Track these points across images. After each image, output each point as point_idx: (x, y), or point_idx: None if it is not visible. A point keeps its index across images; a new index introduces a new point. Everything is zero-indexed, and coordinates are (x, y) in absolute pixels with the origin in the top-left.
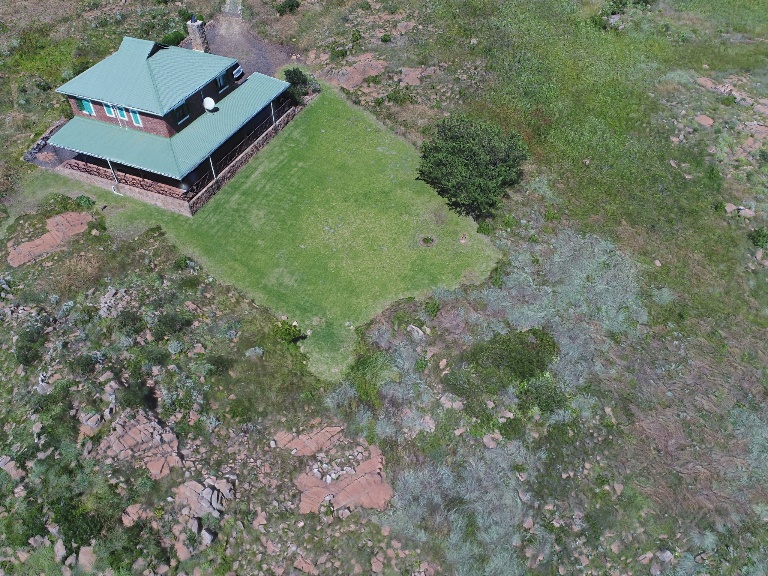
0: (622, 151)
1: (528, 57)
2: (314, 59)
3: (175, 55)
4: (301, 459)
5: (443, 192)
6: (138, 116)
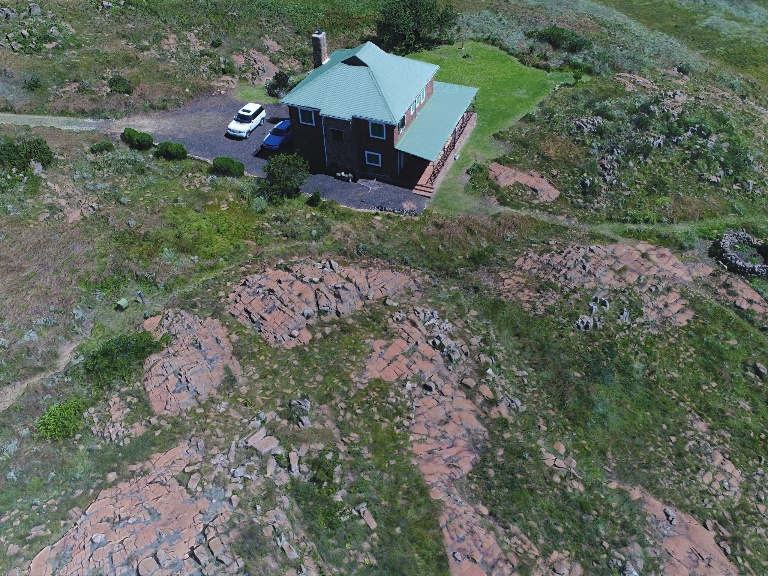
0: (371, 1)
1: (262, 2)
2: (231, 82)
3: None
4: (637, 85)
5: (416, 51)
6: (424, 90)
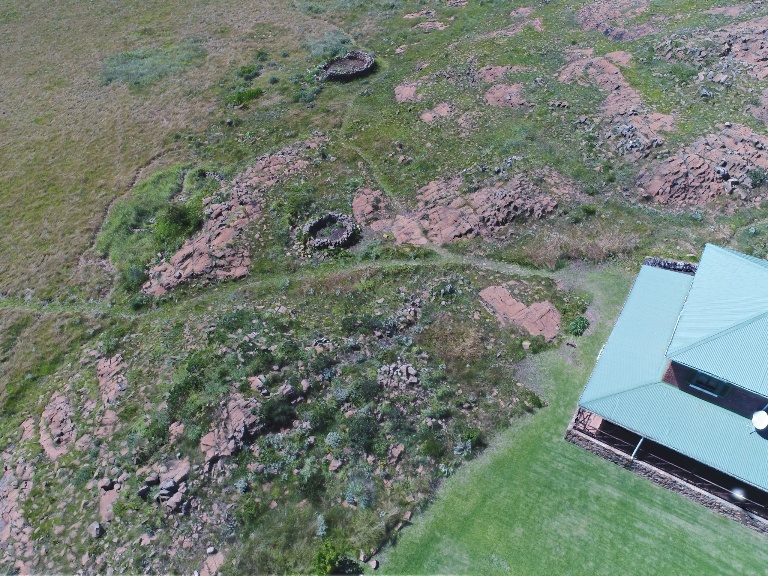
0: None
1: None
2: None
3: None
4: None
5: None
6: None
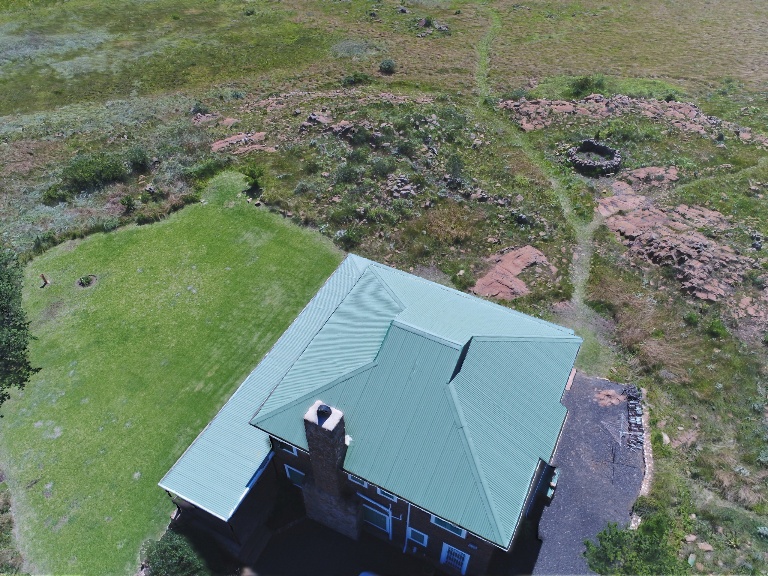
0: None
1: None
2: None
3: (363, 350)
4: (261, 142)
5: None
6: None
